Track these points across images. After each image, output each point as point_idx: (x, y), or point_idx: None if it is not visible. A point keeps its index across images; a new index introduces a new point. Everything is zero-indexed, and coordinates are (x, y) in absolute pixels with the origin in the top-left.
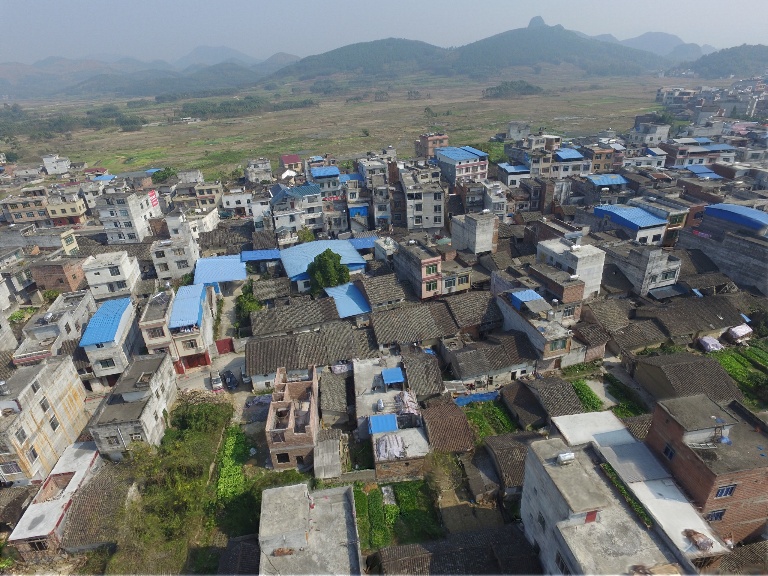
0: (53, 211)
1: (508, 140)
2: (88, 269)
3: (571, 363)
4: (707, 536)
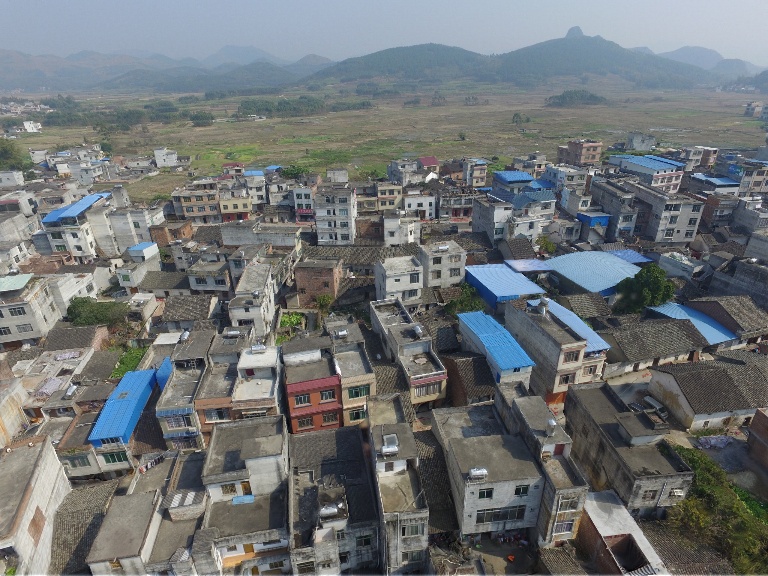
0: (225, 206)
1: (630, 150)
2: (392, 275)
3: None
4: None
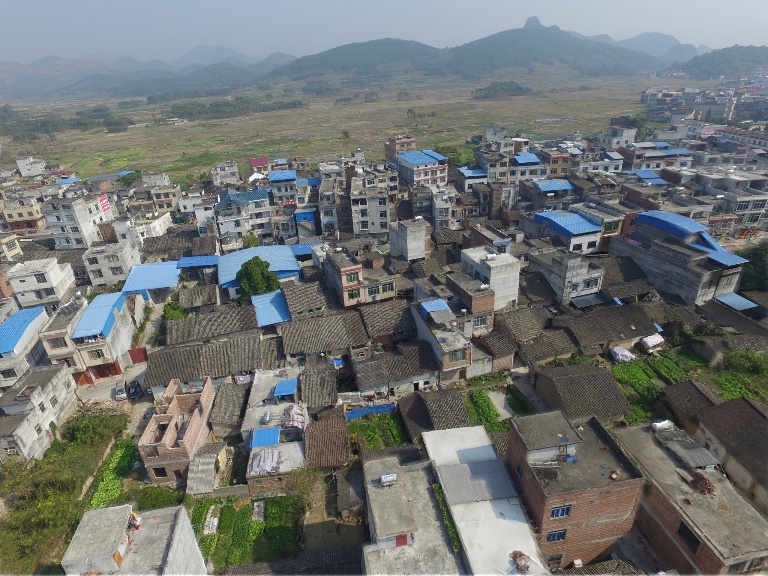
0: (10, 215)
1: (484, 142)
2: (13, 276)
3: (477, 374)
4: (532, 558)
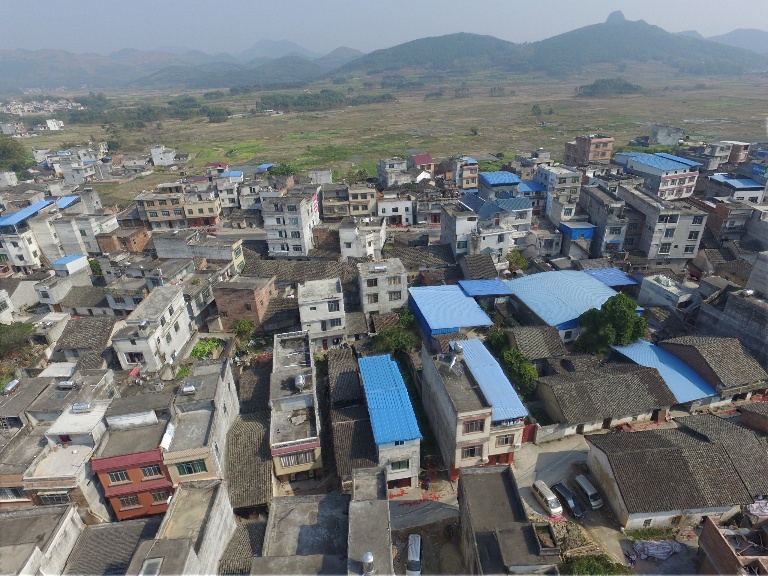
0: (190, 210)
1: (654, 144)
2: (305, 303)
3: None
4: None
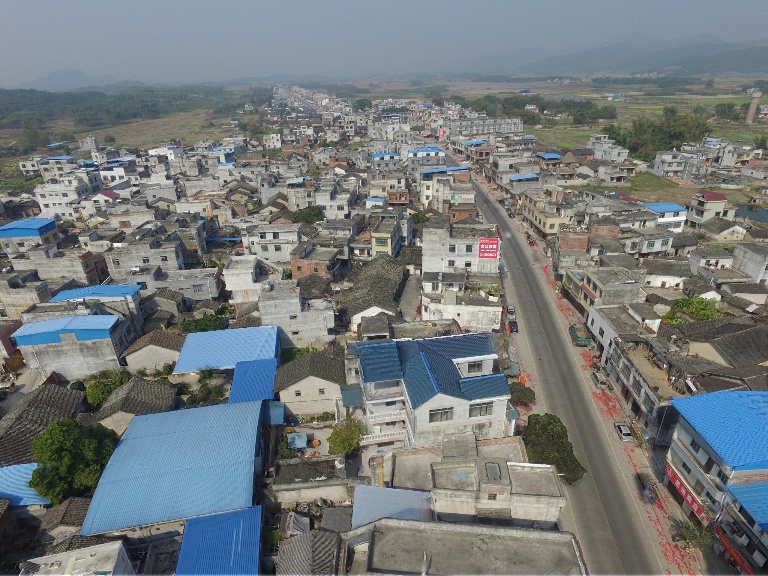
0: None
1: None
2: None
3: None
4: None
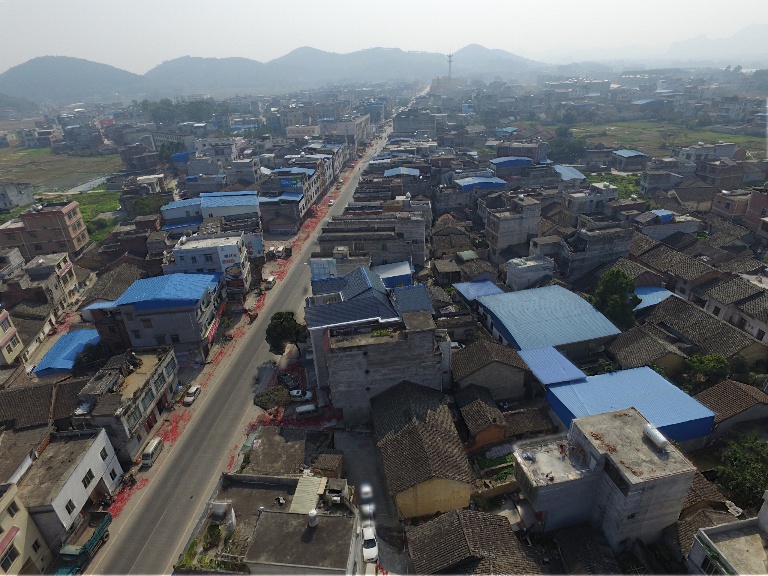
0: None
1: (14, 208)
2: None
3: None
4: None
